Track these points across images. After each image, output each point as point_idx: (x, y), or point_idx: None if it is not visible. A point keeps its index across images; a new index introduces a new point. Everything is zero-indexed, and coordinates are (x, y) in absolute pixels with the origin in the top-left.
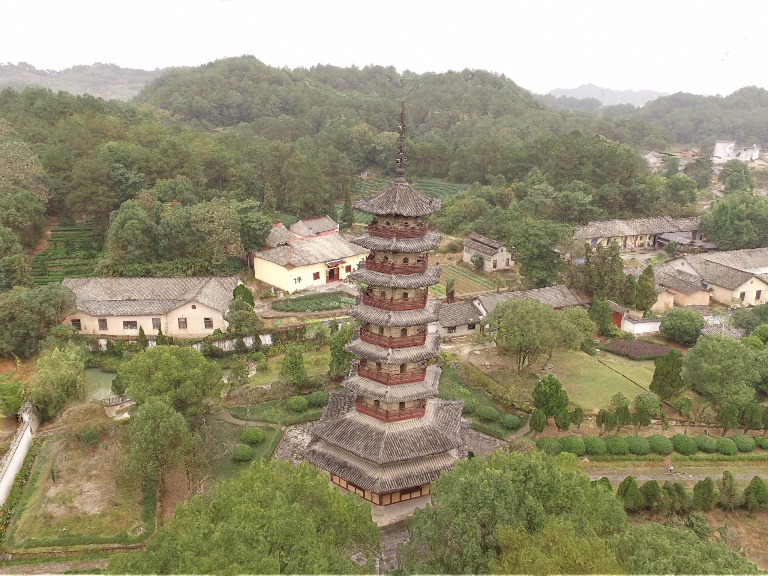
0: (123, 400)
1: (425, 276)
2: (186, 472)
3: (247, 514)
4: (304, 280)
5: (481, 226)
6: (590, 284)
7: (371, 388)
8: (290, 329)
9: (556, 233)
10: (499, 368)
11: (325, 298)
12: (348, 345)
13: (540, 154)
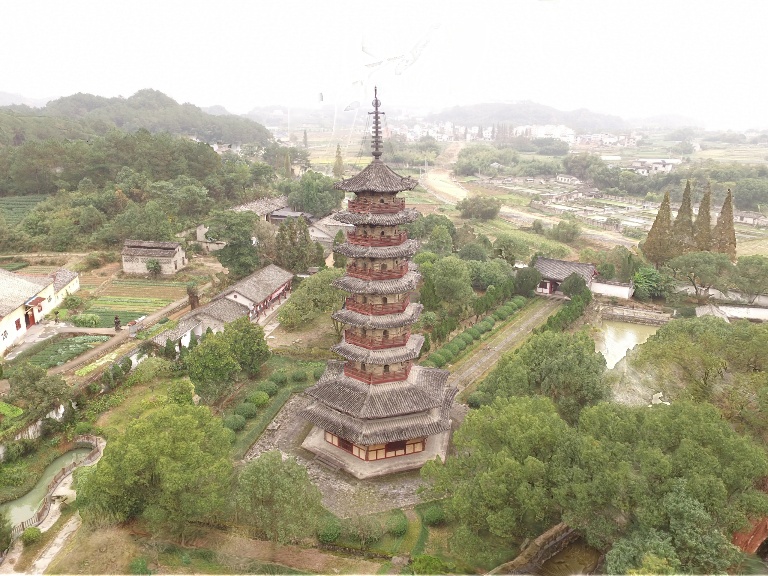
0: (1, 555)
1: (408, 242)
2: (252, 539)
3: (597, 413)
4: (9, 333)
5: (111, 234)
6: (290, 258)
7: (390, 355)
8: (90, 384)
9: (250, 219)
10: (308, 340)
11: (51, 346)
12: (369, 323)
13: (121, 153)
